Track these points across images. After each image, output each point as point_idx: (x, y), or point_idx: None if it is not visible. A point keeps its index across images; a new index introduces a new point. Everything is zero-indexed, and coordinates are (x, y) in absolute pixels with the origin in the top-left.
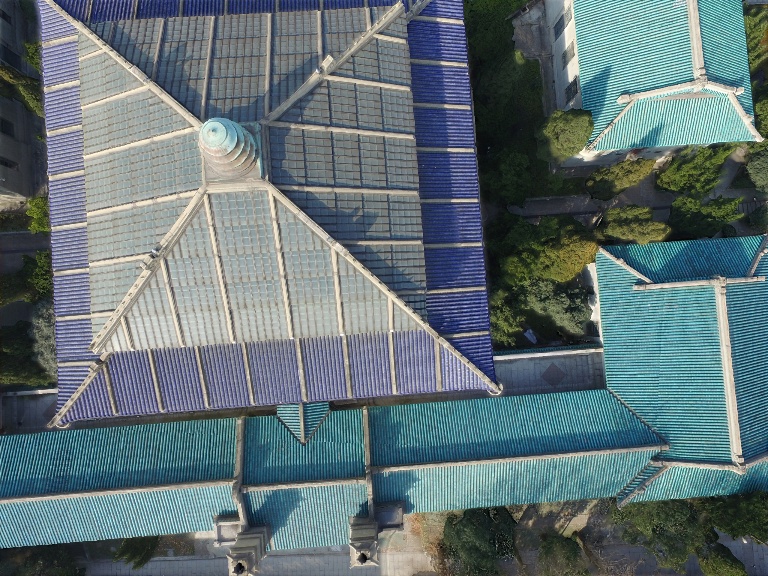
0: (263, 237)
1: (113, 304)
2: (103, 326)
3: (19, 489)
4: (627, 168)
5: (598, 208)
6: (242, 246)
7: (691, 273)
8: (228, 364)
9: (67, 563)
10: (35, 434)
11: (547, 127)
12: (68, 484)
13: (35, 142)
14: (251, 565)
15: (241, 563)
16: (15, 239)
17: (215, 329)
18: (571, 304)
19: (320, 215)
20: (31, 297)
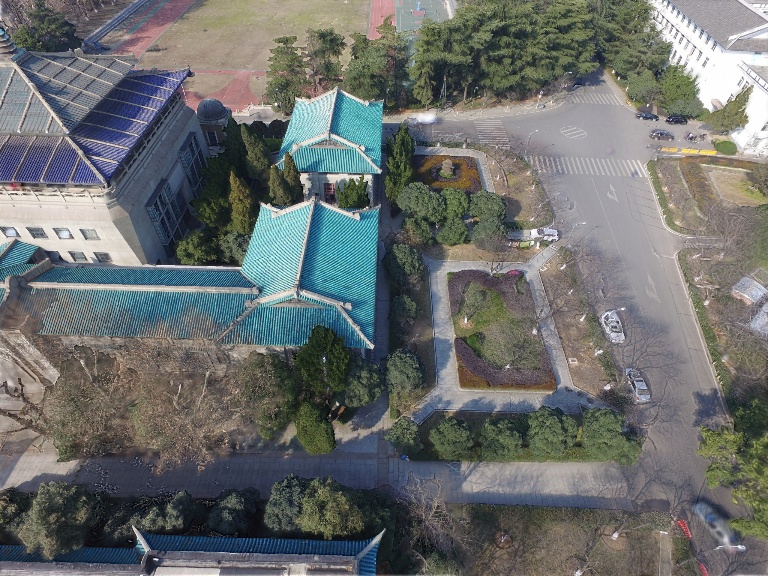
0: (2, 84)
1: None
2: None
3: None
4: None
5: None
6: None
7: None
8: None
9: None
10: None
11: None
12: None
13: None
14: None
15: None
16: None
17: None
18: None
19: None
20: None
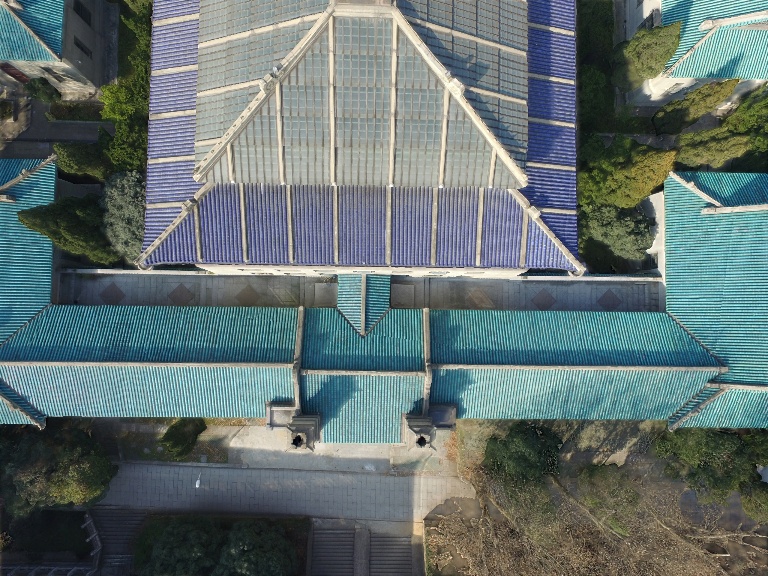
0: (380, 70)
1: (220, 132)
2: (210, 150)
3: (77, 355)
4: (705, 93)
5: None
6: (358, 78)
7: (760, 202)
8: (317, 218)
9: (103, 455)
10: (95, 306)
11: (628, 47)
12: (126, 354)
13: (108, 35)
14: (310, 439)
15: (300, 436)
16: (80, 129)
17: (317, 167)
18: (634, 229)
19: (438, 54)
20: (103, 170)
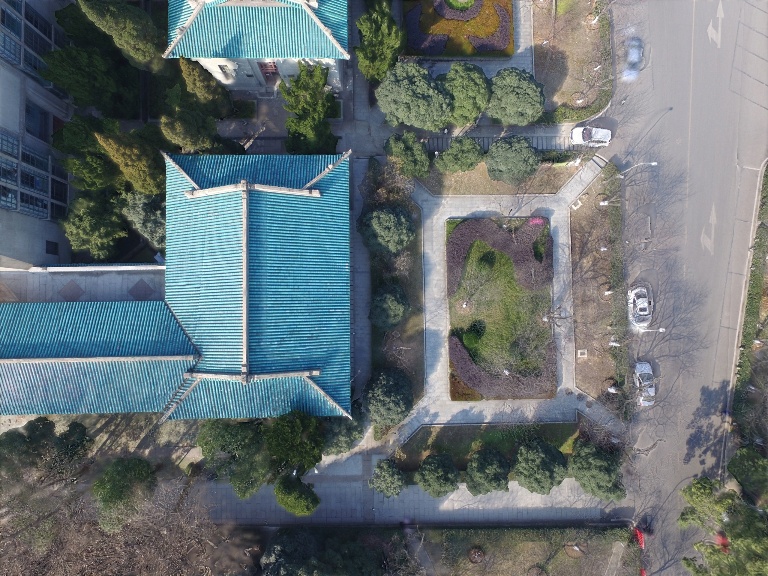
0: None
1: None
2: None
3: None
4: None
5: (244, 134)
6: None
7: None
8: None
9: None
10: None
11: None
12: None
13: None
14: None
15: None
16: None
17: None
18: (151, 216)
19: None
20: None
